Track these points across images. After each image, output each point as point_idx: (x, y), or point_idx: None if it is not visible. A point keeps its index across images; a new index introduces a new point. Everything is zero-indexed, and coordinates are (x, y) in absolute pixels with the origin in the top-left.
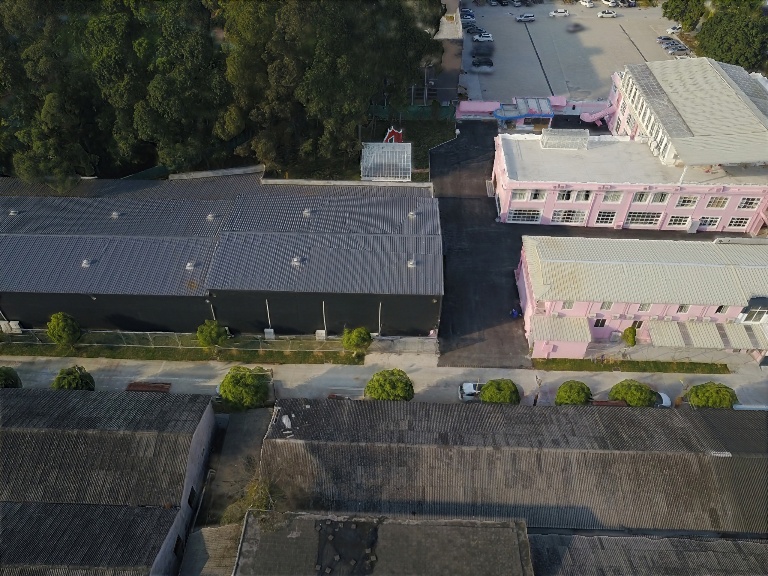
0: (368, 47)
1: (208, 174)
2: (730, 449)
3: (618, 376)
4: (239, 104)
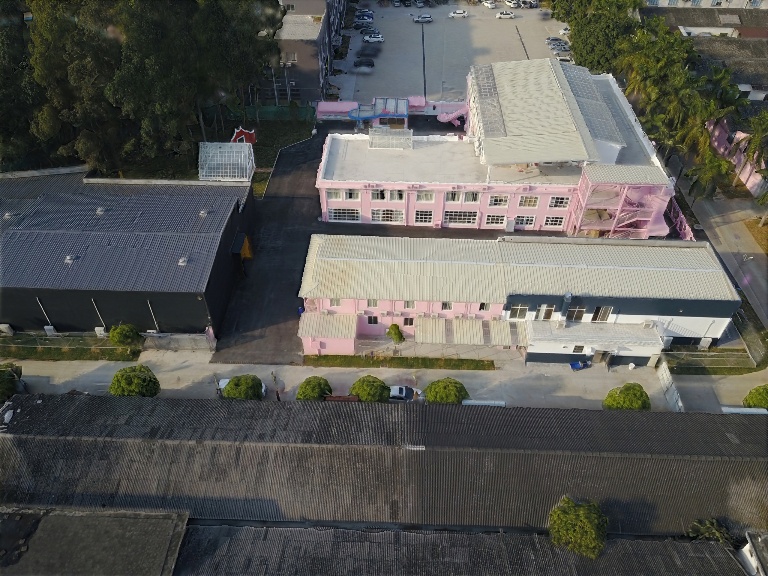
0: (179, 48)
1: (34, 173)
2: (427, 443)
3: (383, 372)
4: (53, 104)
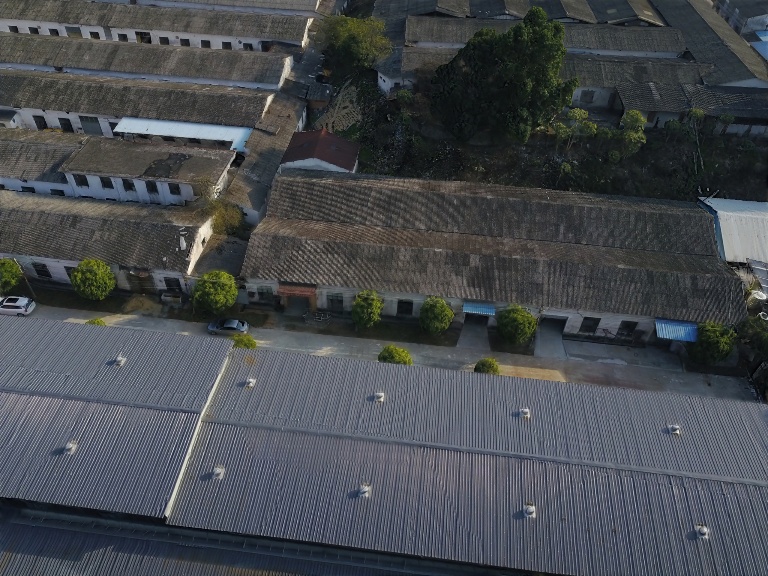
0: None
1: None
2: None
3: None
4: None
